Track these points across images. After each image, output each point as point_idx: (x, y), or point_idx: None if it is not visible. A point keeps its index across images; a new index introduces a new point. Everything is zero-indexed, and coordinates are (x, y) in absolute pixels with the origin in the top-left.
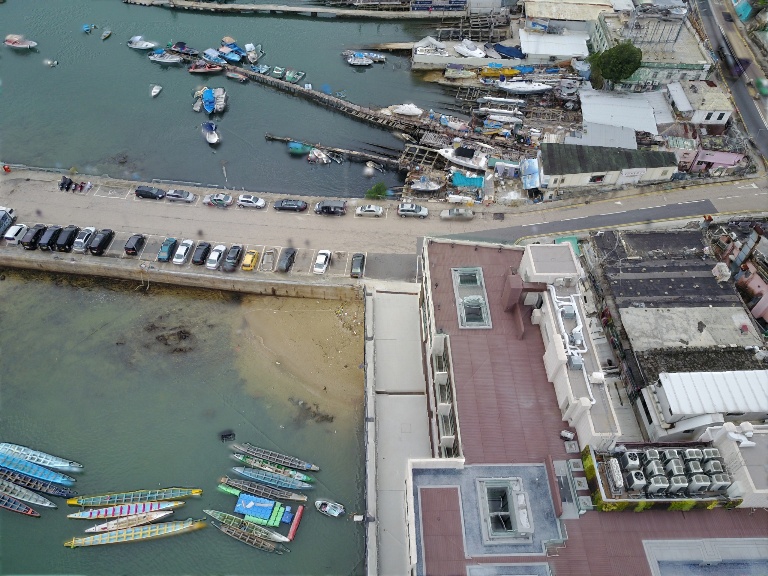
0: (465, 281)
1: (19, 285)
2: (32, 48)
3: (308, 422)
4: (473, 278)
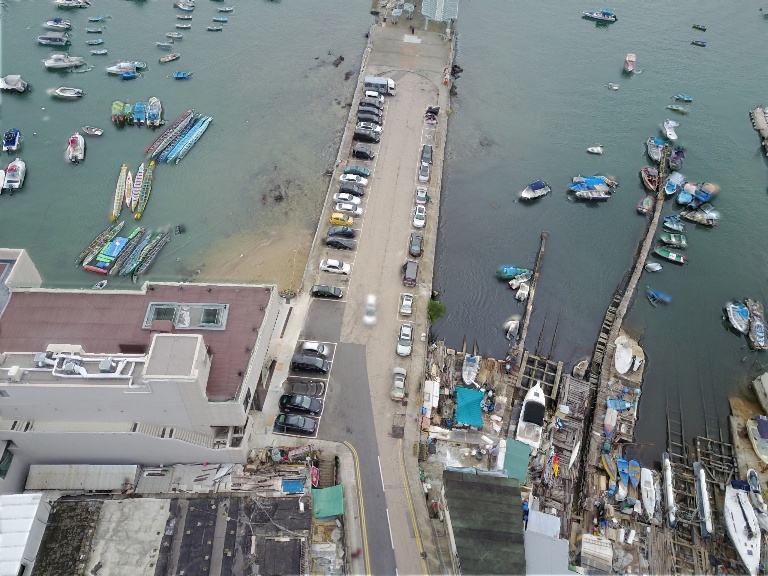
0: (208, 313)
1: (337, 115)
2: (633, 73)
3: (180, 276)
4: (212, 321)
